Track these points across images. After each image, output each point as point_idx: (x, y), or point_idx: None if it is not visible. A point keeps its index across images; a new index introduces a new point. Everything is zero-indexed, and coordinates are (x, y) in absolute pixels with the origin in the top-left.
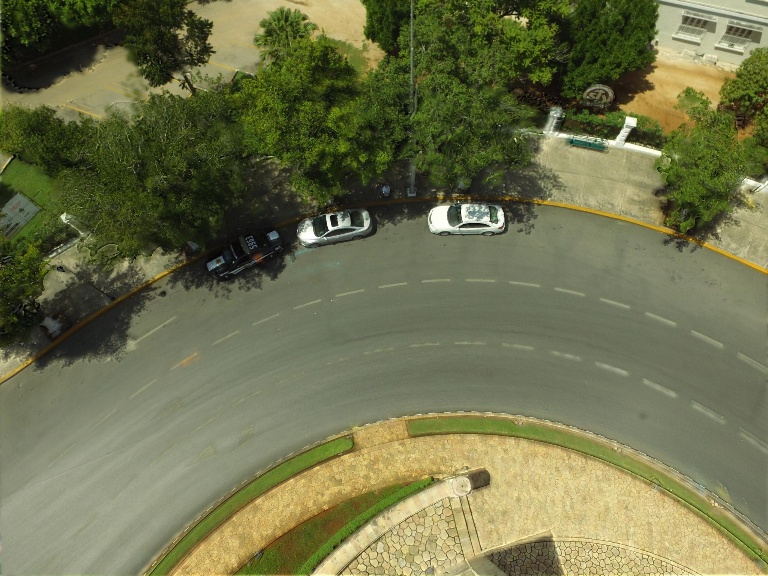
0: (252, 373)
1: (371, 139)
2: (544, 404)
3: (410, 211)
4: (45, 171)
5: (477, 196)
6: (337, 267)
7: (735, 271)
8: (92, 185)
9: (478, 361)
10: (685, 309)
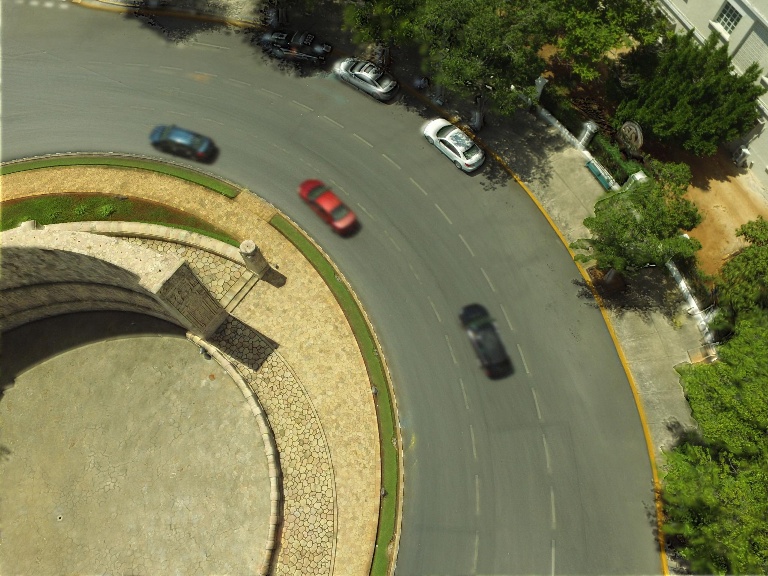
0: (231, 112)
1: (417, 6)
2: (366, 285)
3: (427, 111)
4: None
5: (480, 139)
6: (345, 102)
7: (601, 344)
8: None
9: (358, 225)
10: (531, 329)
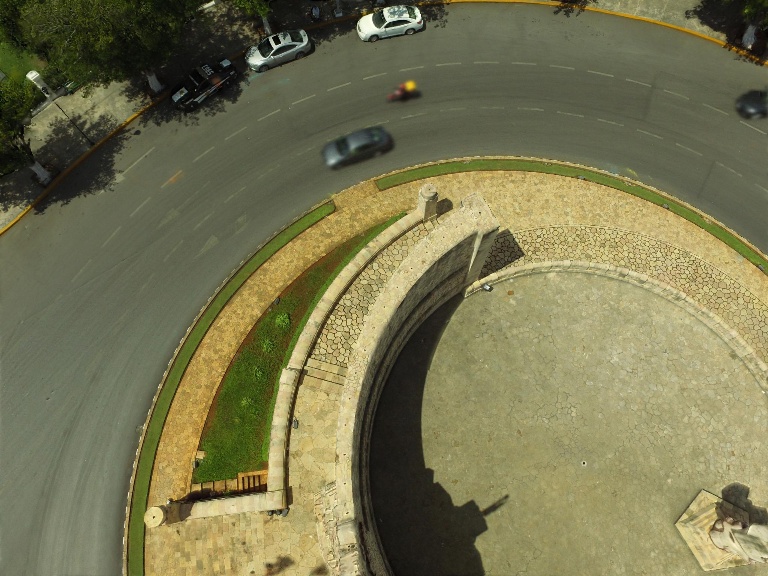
0: (235, 175)
1: None
2: (484, 146)
3: (340, 28)
4: (2, 35)
5: None
6: (288, 82)
7: (613, 23)
8: (58, 4)
9: (424, 127)
10: (580, 57)
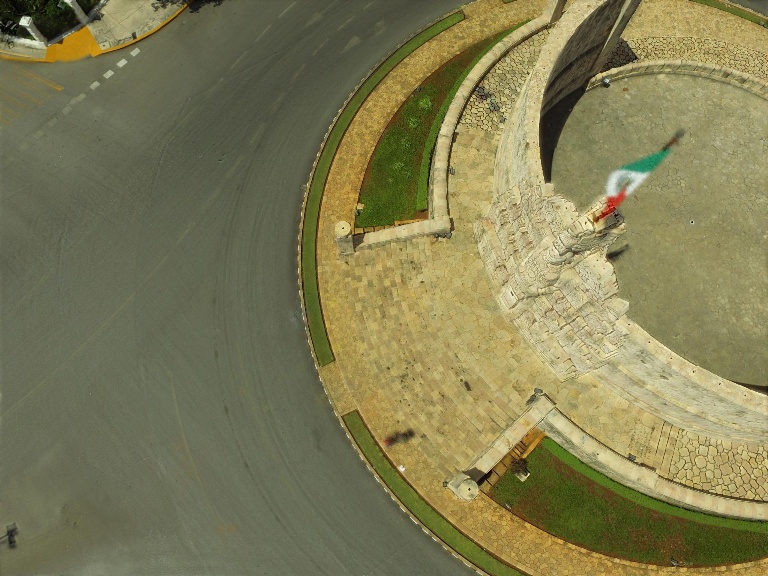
0: None
1: None
2: None
3: None
4: None
5: None
6: None
7: None
8: None
9: None
10: None
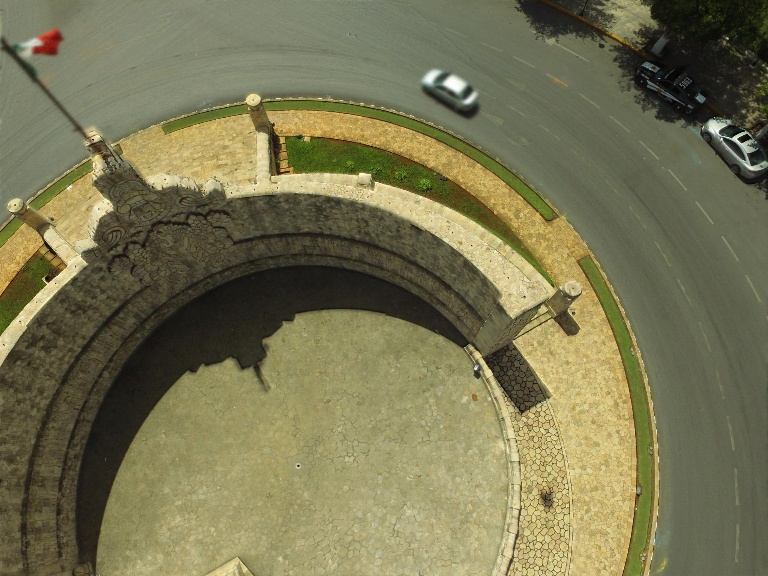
0: (572, 129)
1: None
2: (661, 372)
3: None
4: None
5: None
6: (696, 163)
7: None
8: None
9: (672, 304)
10: None
